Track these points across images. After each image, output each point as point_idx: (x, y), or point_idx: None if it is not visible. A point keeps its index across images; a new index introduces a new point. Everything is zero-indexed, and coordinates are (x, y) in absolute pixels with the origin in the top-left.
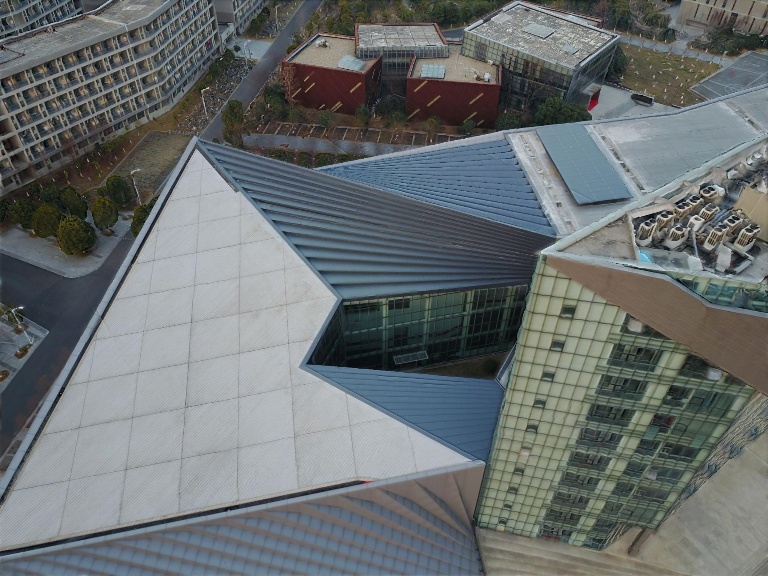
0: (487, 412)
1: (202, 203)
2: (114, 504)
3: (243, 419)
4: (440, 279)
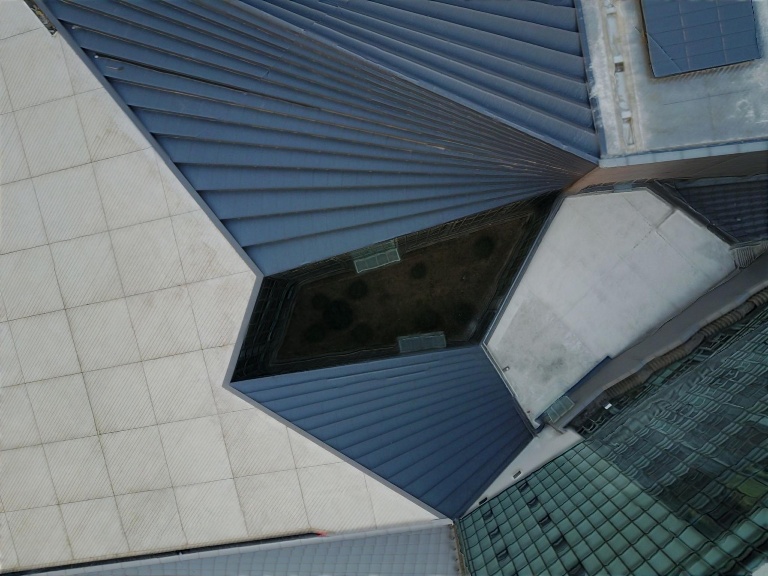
0: (465, 411)
1: (4, 62)
2: (61, 540)
3: (169, 453)
4: (408, 213)
